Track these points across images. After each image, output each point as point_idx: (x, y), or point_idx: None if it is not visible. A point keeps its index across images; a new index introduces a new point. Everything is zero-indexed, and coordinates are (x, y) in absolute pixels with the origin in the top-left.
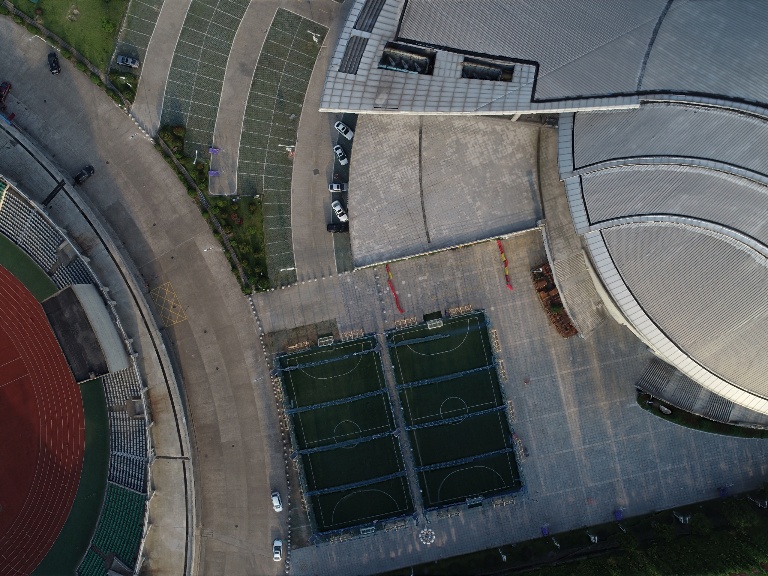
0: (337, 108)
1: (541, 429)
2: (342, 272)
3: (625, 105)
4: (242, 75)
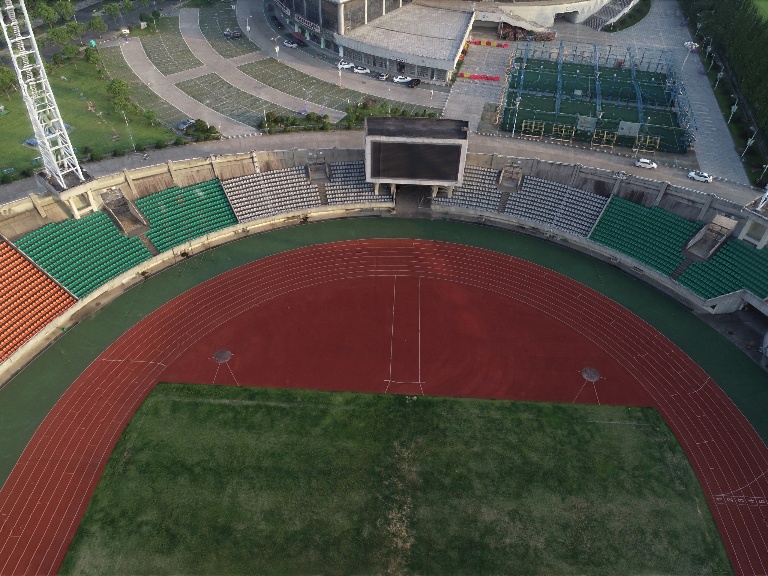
0: None
1: None
2: None
3: None
4: (262, 89)
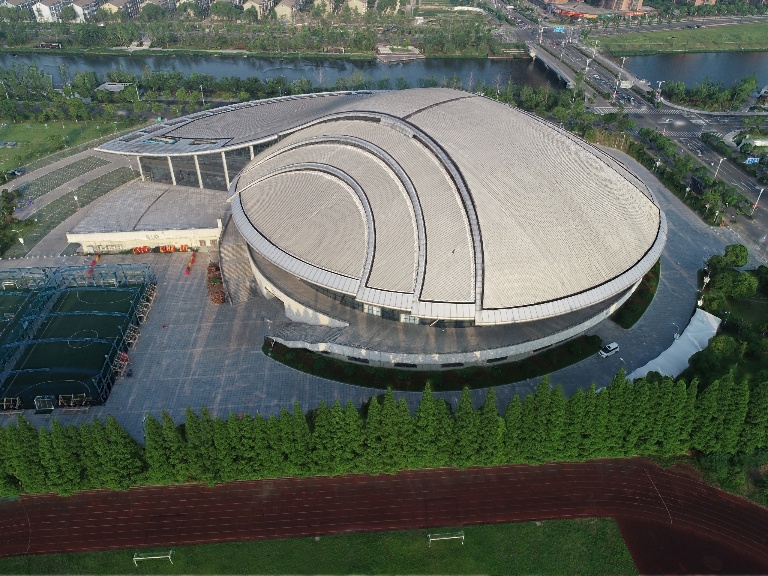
0: (106, 149)
1: (157, 360)
2: (62, 256)
3: (270, 137)
4: None
